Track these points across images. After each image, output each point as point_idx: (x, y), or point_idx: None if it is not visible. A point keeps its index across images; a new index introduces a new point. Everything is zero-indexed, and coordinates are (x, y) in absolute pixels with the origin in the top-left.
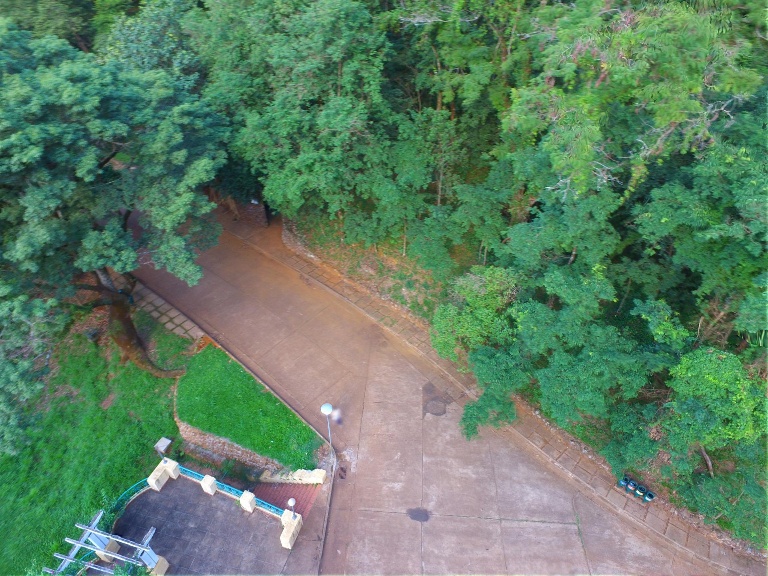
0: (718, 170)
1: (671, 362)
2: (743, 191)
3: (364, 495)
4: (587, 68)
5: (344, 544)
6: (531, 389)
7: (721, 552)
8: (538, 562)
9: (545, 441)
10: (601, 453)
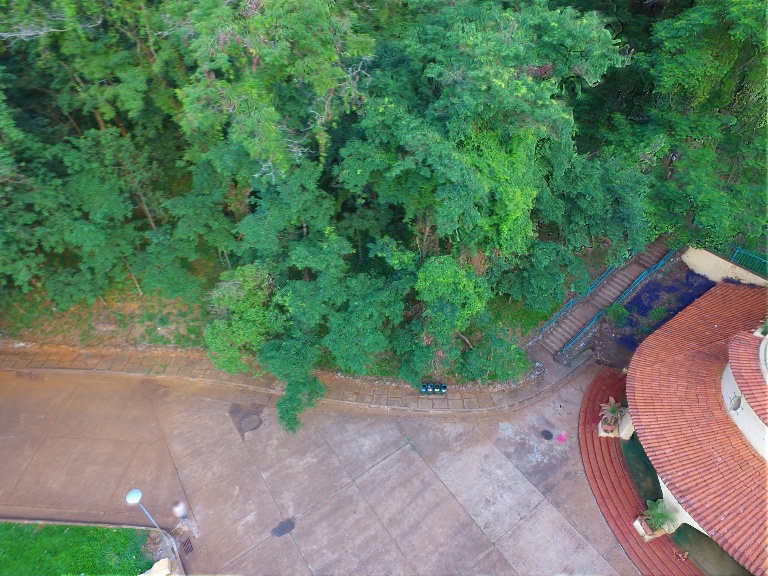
0: (378, 120)
1: (413, 281)
2: (400, 131)
3: (222, 550)
4: (238, 56)
5: None
6: (325, 358)
7: (499, 397)
8: (396, 492)
9: (356, 394)
10: (399, 377)
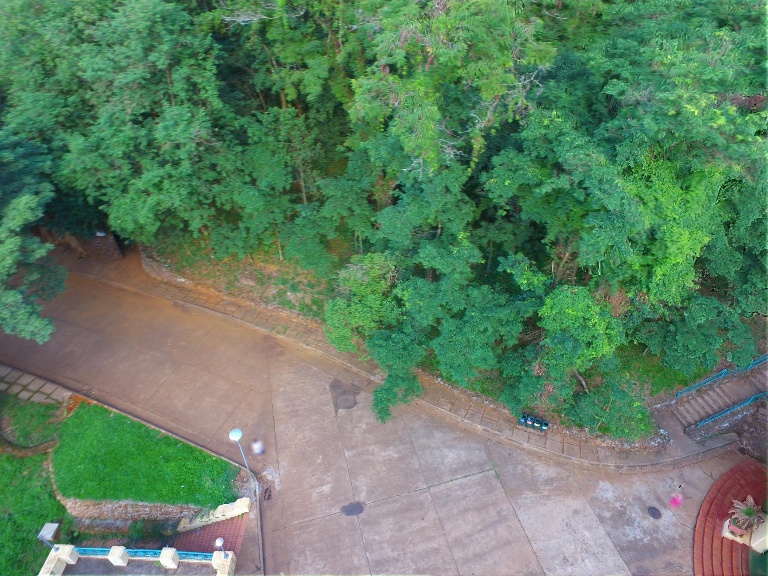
0: (540, 132)
1: (538, 305)
2: (562, 148)
3: (295, 509)
4: (415, 53)
5: (285, 564)
6: (429, 360)
7: (606, 453)
8: (469, 514)
9: (451, 403)
10: (500, 400)
